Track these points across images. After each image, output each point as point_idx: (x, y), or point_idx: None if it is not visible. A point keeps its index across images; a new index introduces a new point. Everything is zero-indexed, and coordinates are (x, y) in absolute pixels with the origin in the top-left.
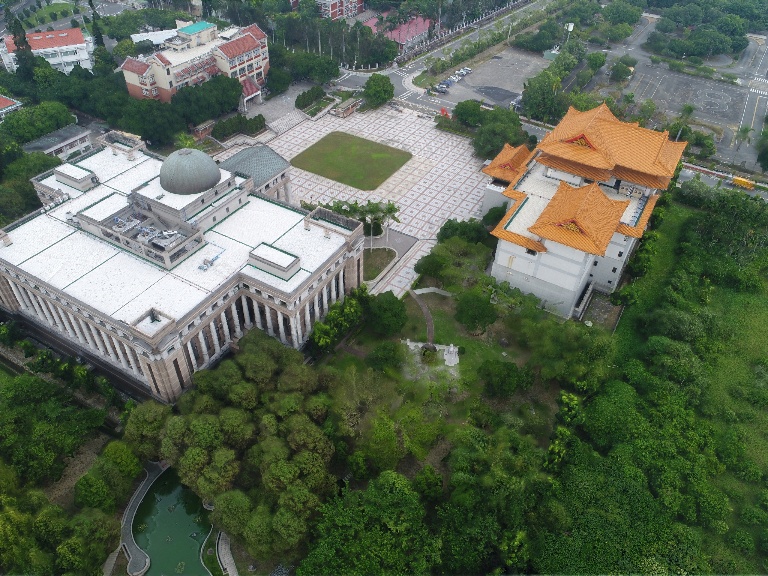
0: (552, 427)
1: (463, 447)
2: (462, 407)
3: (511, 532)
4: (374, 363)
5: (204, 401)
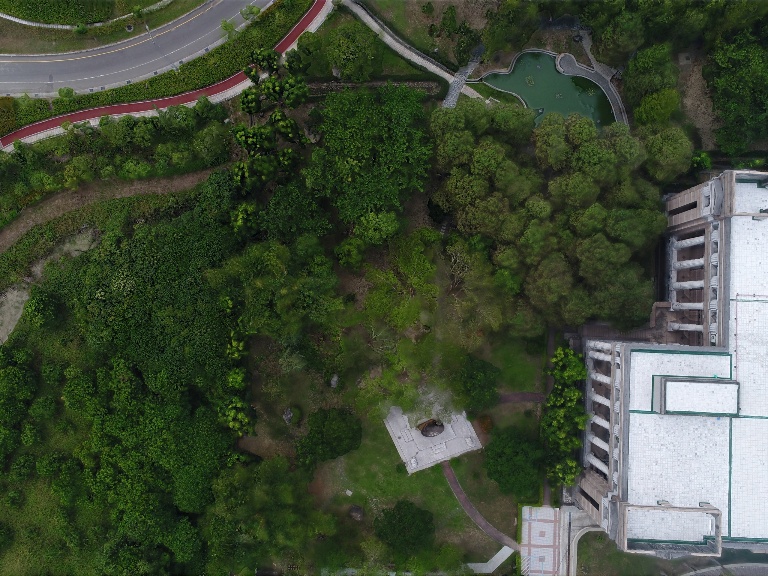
0: (261, 411)
1: (329, 293)
2: (355, 354)
3: (255, 244)
4: (486, 371)
5: (626, 191)
